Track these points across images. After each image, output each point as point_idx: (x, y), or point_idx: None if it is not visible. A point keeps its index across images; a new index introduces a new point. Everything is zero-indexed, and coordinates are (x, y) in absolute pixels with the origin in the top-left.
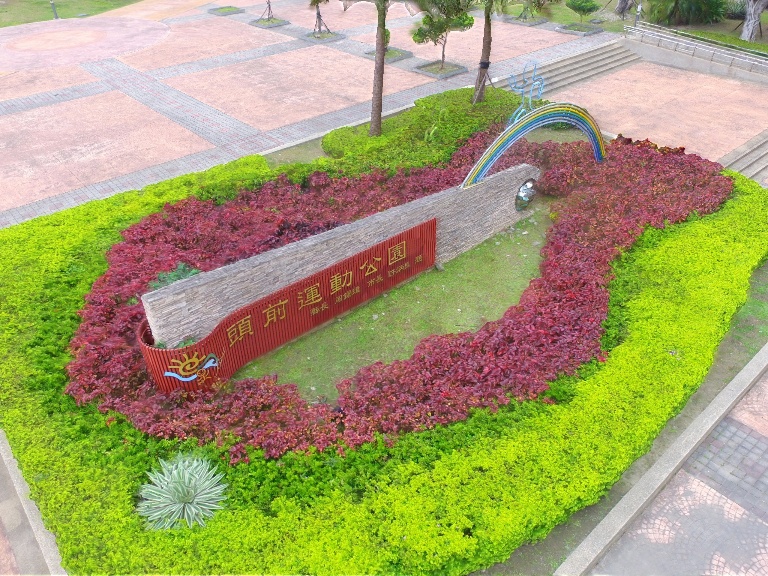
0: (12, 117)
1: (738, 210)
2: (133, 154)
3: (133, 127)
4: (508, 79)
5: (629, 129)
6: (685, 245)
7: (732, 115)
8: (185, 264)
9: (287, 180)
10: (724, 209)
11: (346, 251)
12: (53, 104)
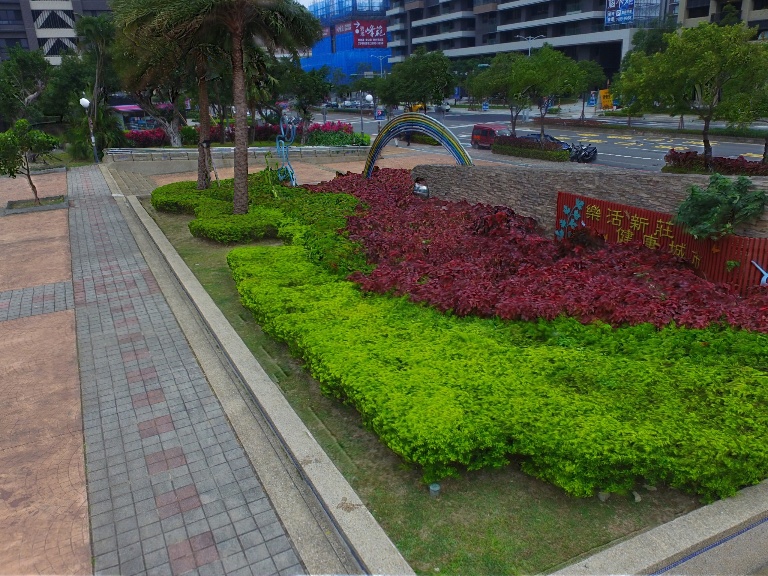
0: None
1: None
2: None
3: None
4: None
5: None
6: None
7: None
8: None
9: None
10: None
11: None
12: None
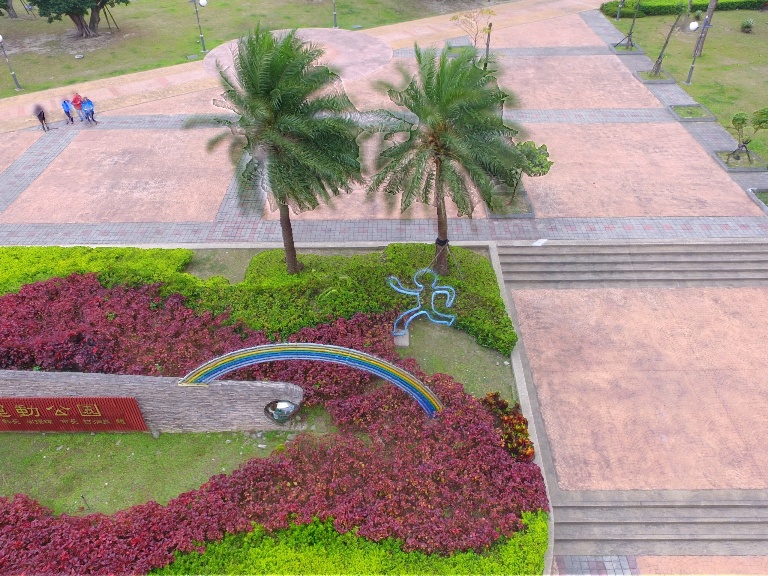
0: (166, 133)
1: (449, 573)
2: (164, 204)
3: (203, 175)
4: (559, 246)
5: (591, 382)
6: (314, 568)
7: (767, 437)
8: (7, 334)
9: (155, 291)
10: (445, 559)
11: (36, 391)
12: (201, 128)
